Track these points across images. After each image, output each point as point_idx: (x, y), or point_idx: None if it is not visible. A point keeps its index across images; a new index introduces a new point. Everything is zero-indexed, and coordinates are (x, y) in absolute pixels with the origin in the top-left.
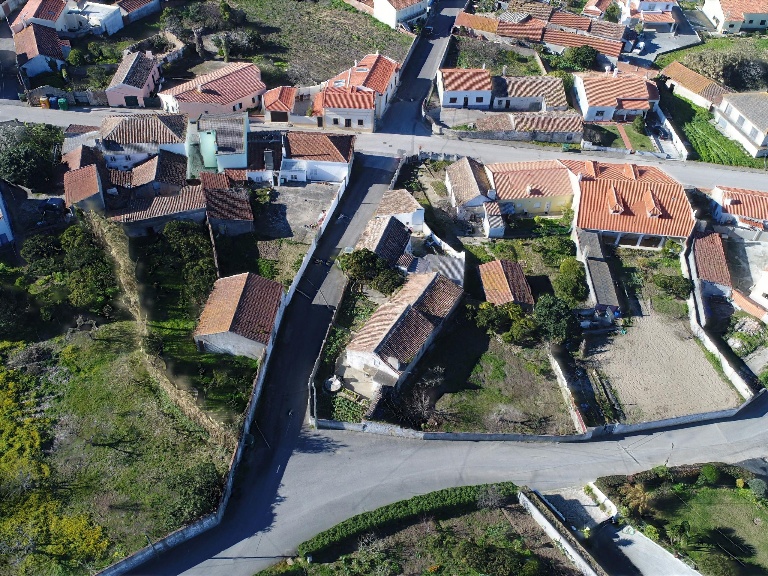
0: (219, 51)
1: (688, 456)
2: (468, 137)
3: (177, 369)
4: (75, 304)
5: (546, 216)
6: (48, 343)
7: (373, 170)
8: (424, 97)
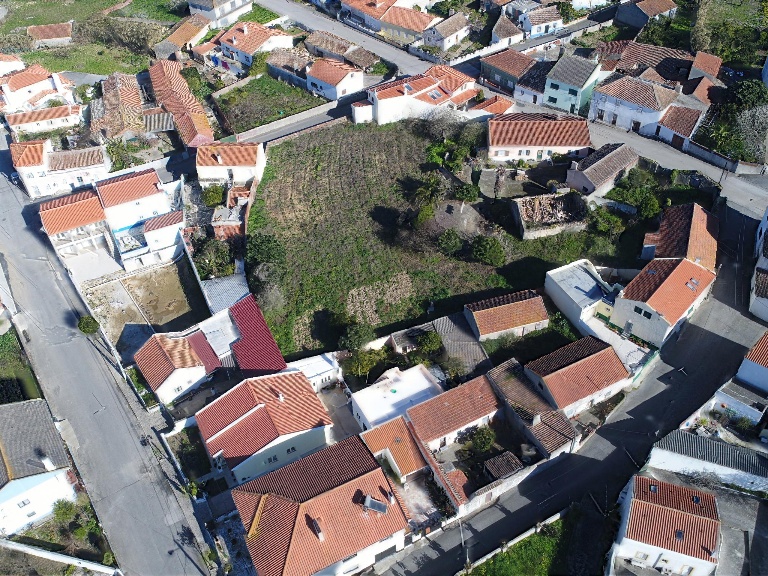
0: None
1: None
2: None
3: None
4: None
5: None
6: None
7: (480, 67)
8: None
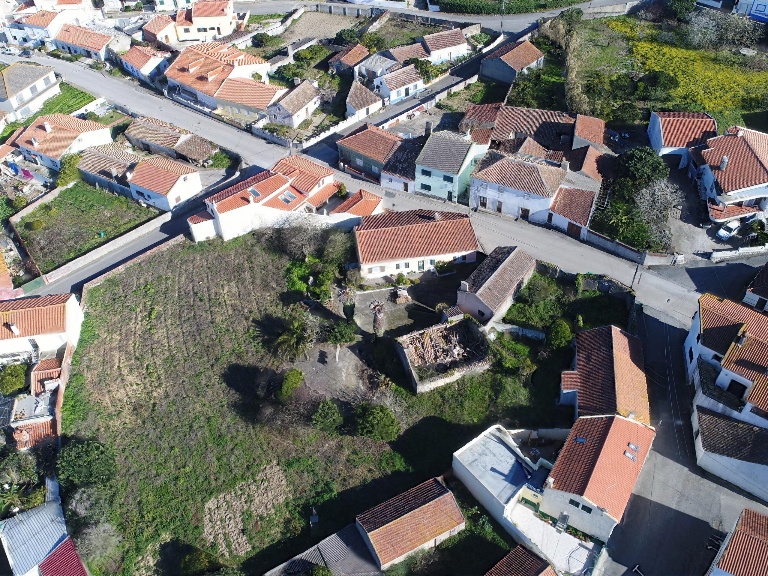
0: None
1: (355, 7)
2: None
3: (558, 62)
4: None
5: None
6: None
7: None
8: (201, 206)
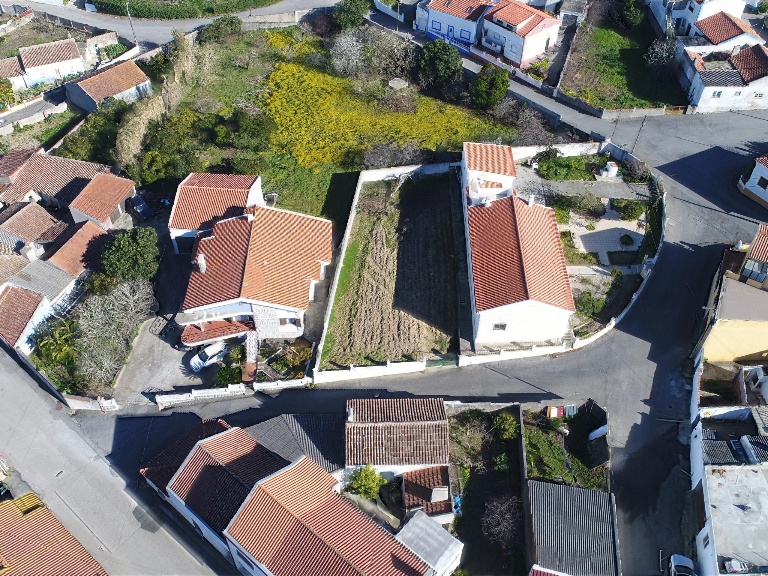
0: None
1: (7, 2)
2: None
3: None
4: (198, 116)
5: None
6: None
7: None
8: None
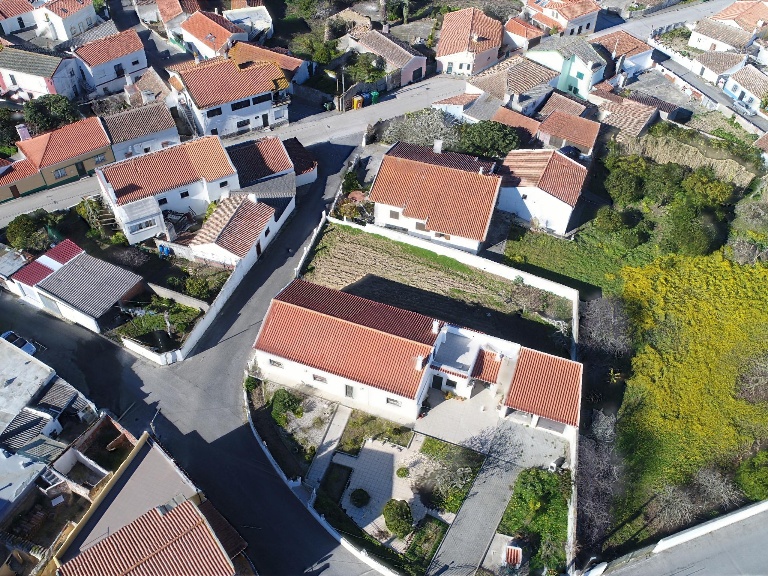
0: (390, 17)
1: None
2: (648, 13)
3: None
4: (721, 200)
5: (767, 42)
6: (733, 239)
7: None
8: None
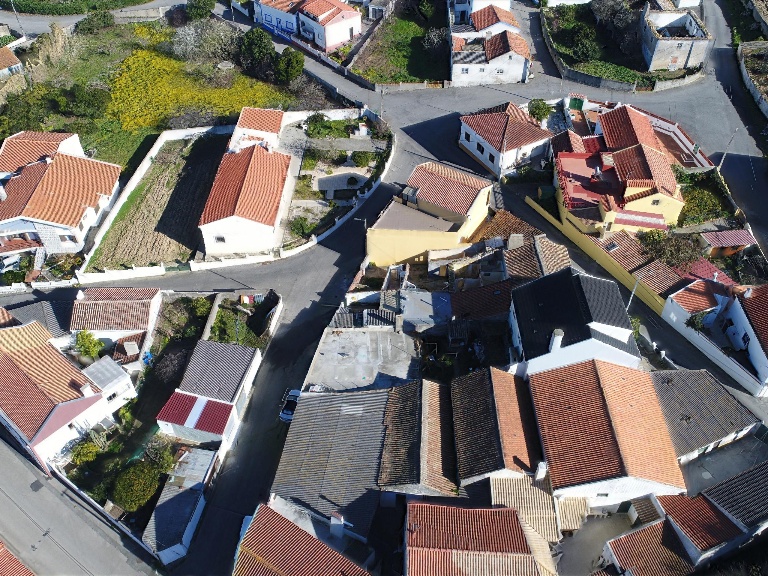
0: None
1: None
2: None
3: None
4: (50, 90)
5: None
6: None
7: None
8: None
